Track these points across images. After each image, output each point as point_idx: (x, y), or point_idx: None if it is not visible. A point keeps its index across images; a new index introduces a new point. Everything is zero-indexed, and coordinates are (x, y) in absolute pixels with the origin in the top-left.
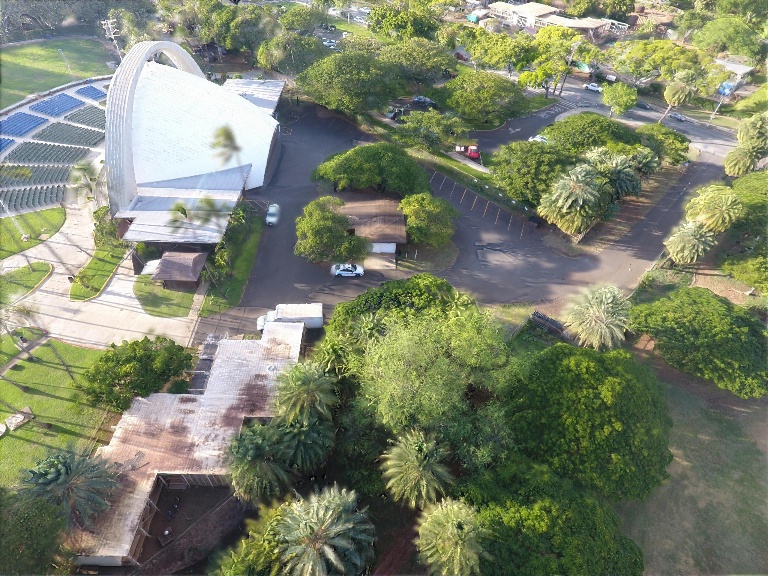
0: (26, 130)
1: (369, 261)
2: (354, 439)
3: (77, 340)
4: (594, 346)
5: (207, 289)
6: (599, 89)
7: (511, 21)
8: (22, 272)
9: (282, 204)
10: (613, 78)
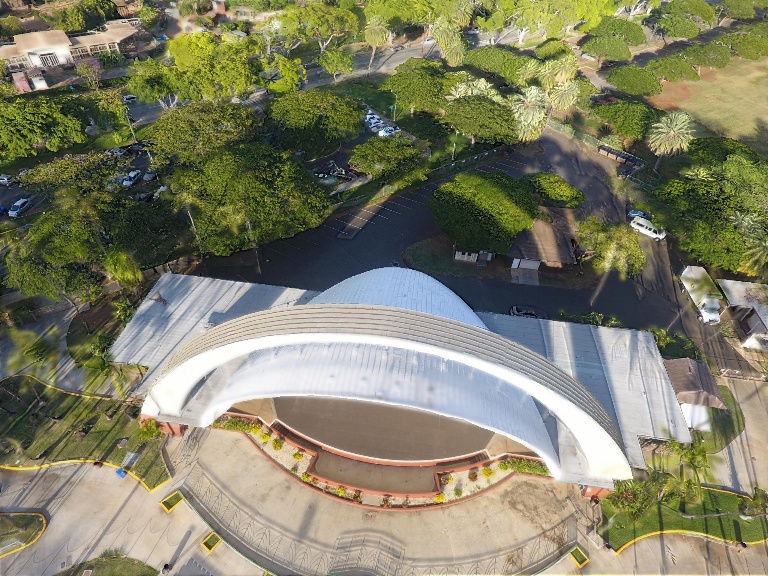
0: None
1: None
2: None
3: None
4: (689, 146)
5: None
6: None
7: (32, 66)
8: None
9: (498, 308)
10: None
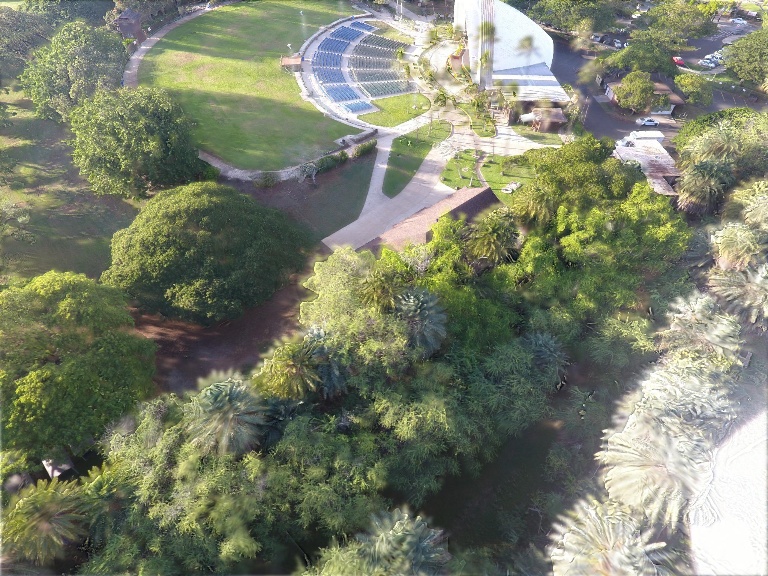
0: (344, 49)
1: (656, 119)
2: (746, 175)
3: (507, 155)
4: None
5: (564, 132)
6: (744, 22)
7: None
8: (435, 124)
9: None
10: (754, 13)
